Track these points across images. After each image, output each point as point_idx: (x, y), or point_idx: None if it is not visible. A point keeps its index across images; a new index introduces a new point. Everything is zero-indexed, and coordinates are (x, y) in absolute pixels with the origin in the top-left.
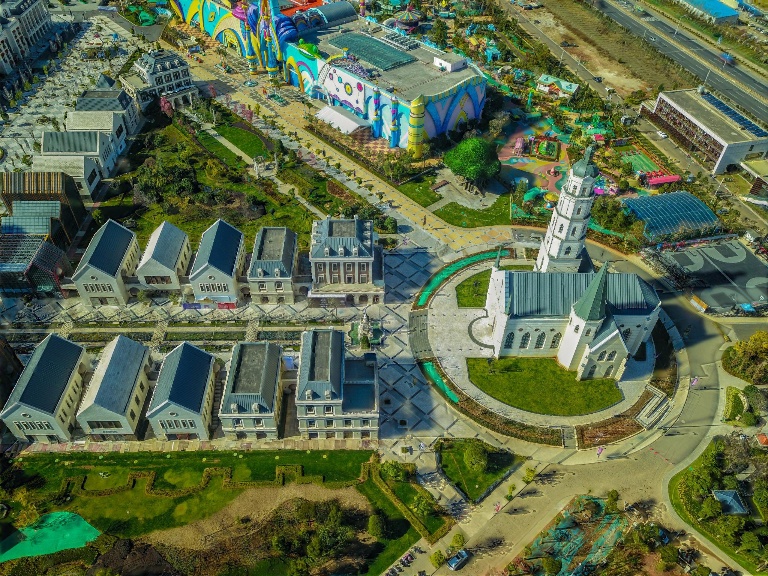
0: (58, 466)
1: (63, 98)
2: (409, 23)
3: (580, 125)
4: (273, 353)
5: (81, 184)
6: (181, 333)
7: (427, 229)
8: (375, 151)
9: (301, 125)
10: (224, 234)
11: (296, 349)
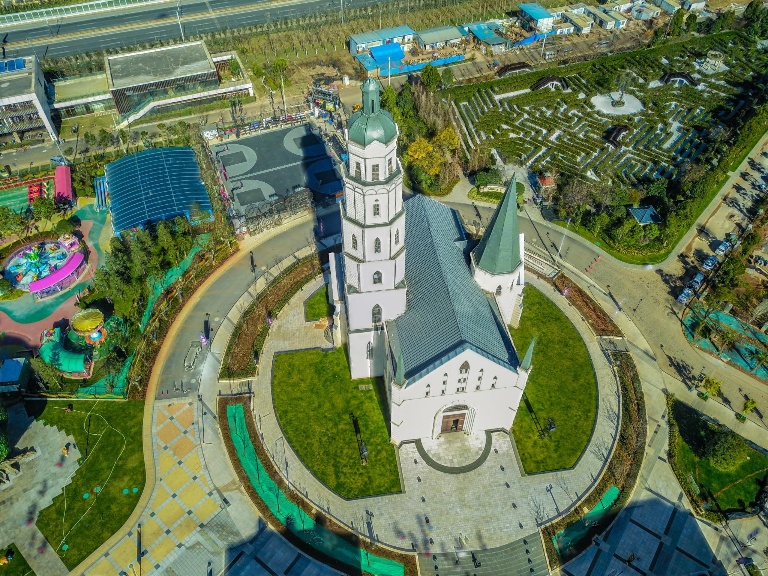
0: None
1: None
2: None
3: None
4: None
5: None
6: None
7: None
8: None
9: None
10: None
11: None
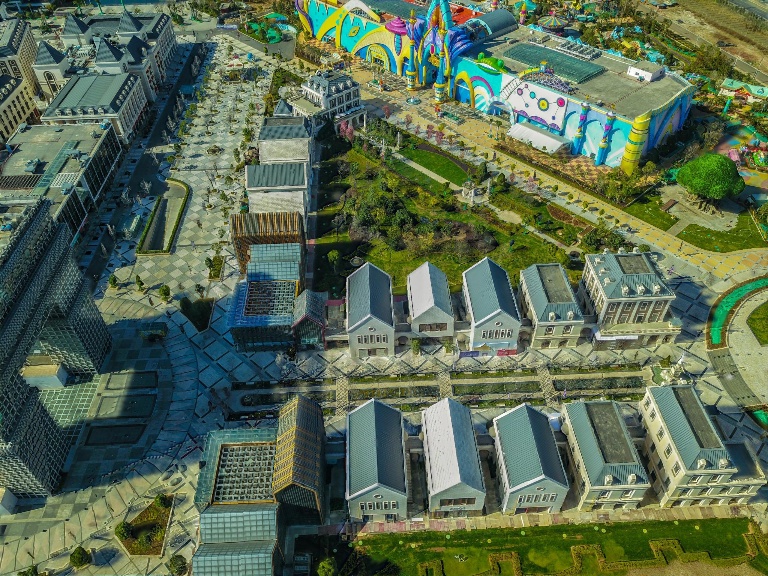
0: (405, 549)
1: (223, 125)
2: (556, 29)
3: None
4: None
5: None
6: (469, 386)
7: (680, 255)
8: (581, 170)
9: (489, 144)
10: (496, 274)
11: None
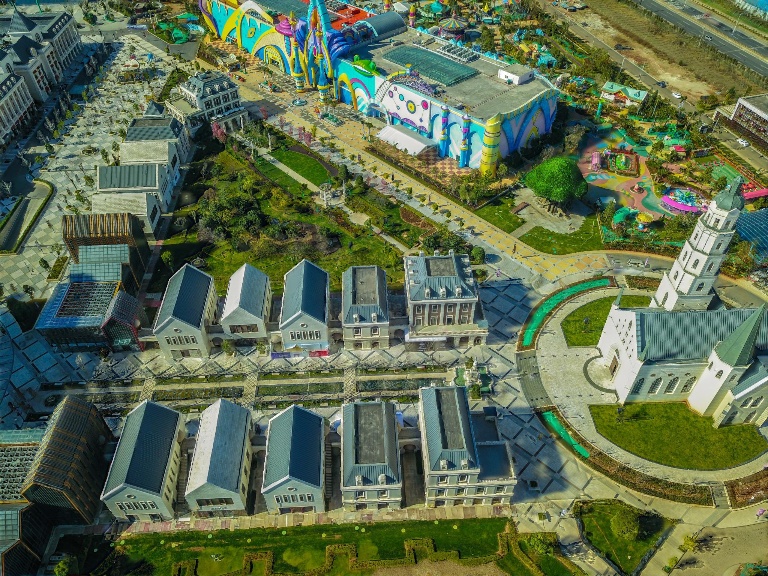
0: (165, 549)
1: (106, 125)
2: (455, 31)
3: (654, 135)
4: (389, 413)
5: (144, 222)
6: (273, 387)
7: (516, 258)
8: (444, 172)
9: (361, 146)
10: (311, 276)
11: (401, 401)
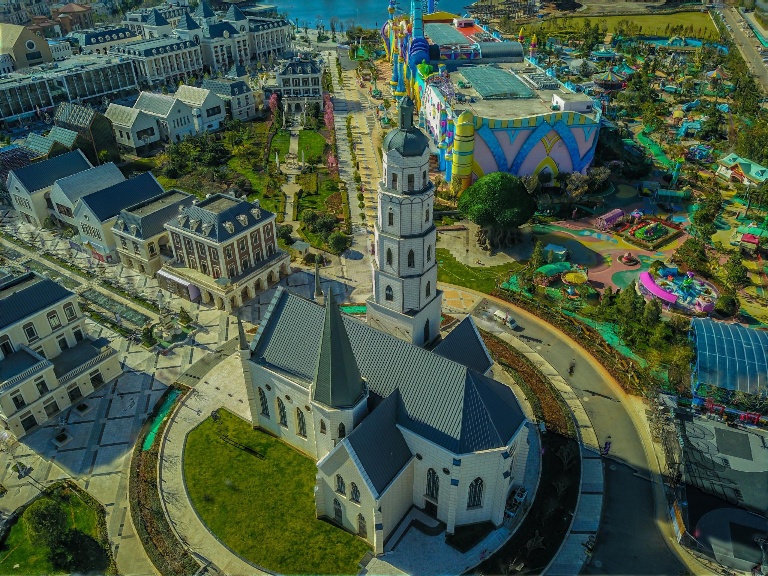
0: None
1: None
2: (605, 85)
3: None
4: None
5: (129, 135)
6: (40, 264)
7: None
8: None
9: (380, 145)
10: (139, 185)
11: (93, 317)
